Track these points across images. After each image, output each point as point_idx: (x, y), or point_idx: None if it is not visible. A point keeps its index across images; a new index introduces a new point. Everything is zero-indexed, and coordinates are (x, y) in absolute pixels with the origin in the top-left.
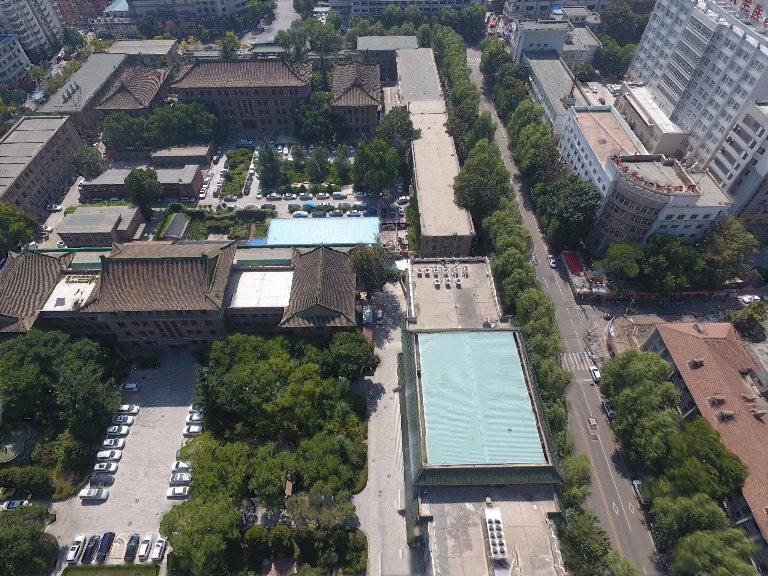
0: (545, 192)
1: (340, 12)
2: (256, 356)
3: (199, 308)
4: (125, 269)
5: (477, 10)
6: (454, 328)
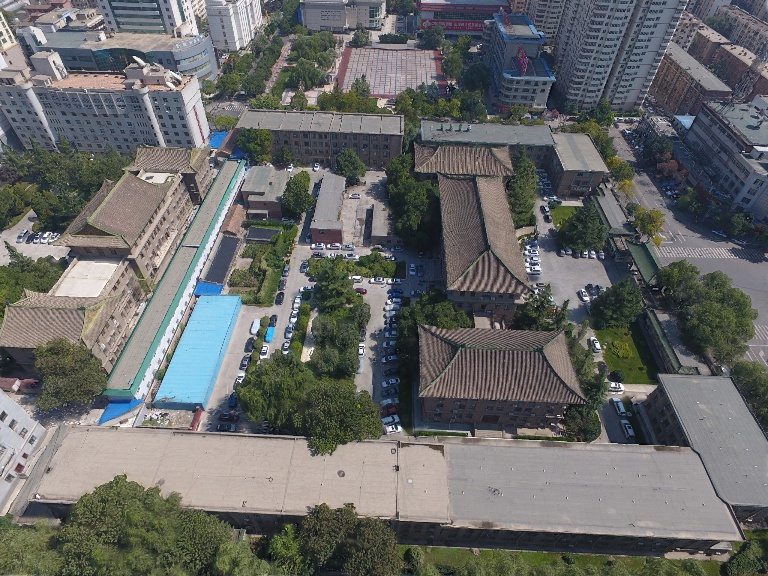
0: None
1: None
2: (25, 285)
3: None
4: None
5: None
6: None
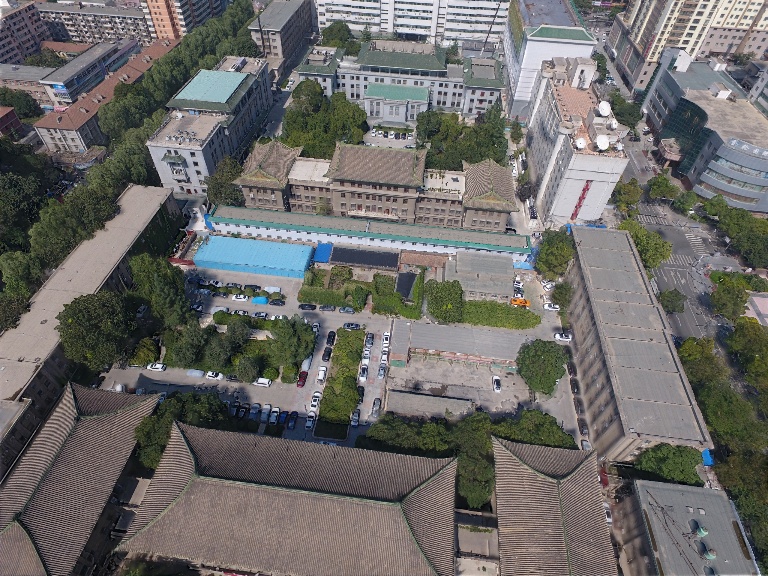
0: (5, 242)
1: None
2: None
3: None
4: None
5: None
6: (202, 108)
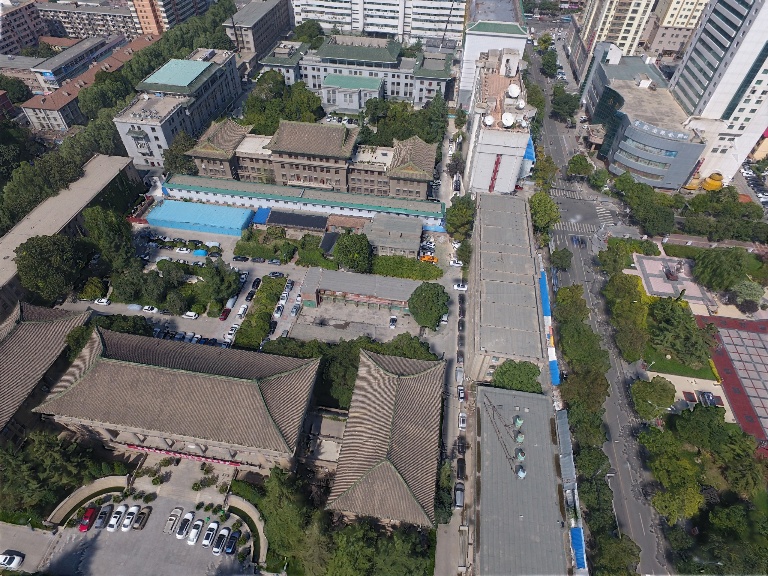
0: None
1: None
2: None
3: None
4: None
5: None
6: (167, 91)
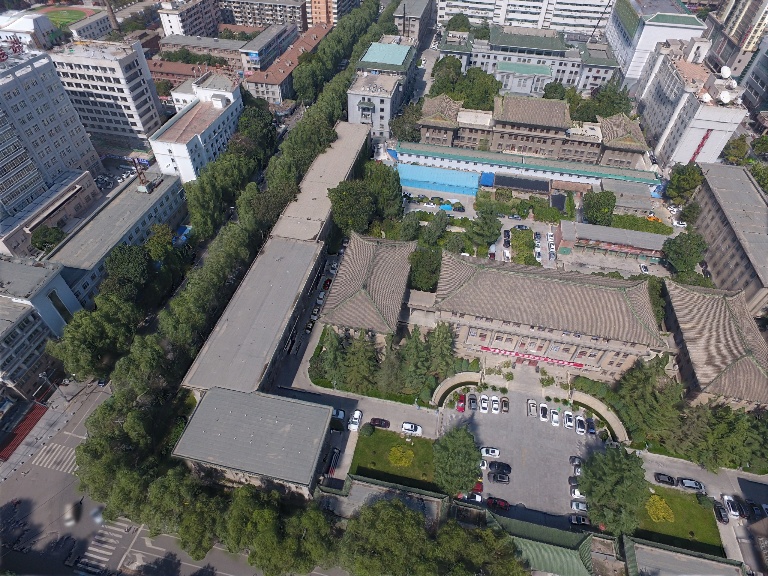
0: None
1: None
2: None
3: None
4: None
5: None
6: (383, 69)
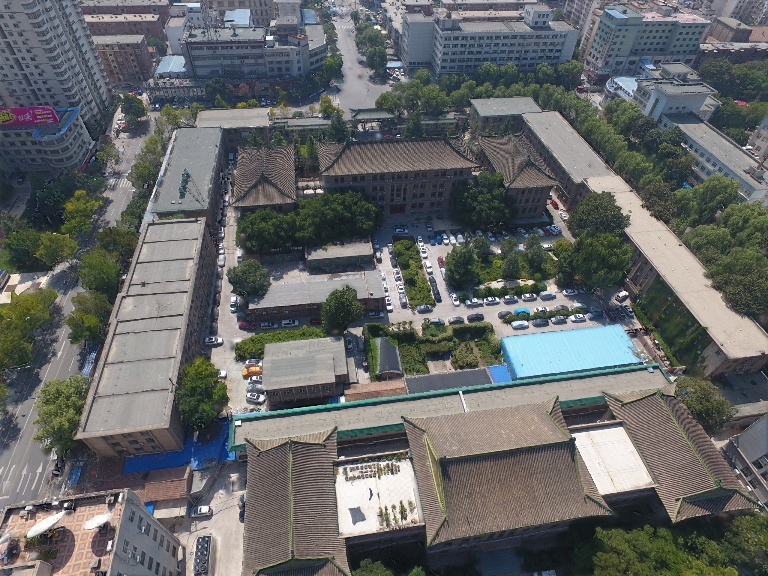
0: None
1: (417, 68)
2: (652, 566)
3: (582, 514)
4: (470, 469)
5: (576, 67)
6: None
